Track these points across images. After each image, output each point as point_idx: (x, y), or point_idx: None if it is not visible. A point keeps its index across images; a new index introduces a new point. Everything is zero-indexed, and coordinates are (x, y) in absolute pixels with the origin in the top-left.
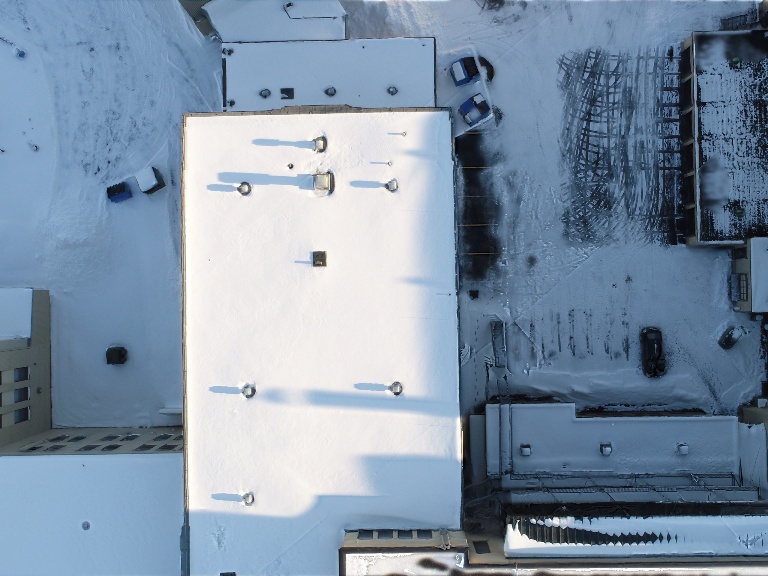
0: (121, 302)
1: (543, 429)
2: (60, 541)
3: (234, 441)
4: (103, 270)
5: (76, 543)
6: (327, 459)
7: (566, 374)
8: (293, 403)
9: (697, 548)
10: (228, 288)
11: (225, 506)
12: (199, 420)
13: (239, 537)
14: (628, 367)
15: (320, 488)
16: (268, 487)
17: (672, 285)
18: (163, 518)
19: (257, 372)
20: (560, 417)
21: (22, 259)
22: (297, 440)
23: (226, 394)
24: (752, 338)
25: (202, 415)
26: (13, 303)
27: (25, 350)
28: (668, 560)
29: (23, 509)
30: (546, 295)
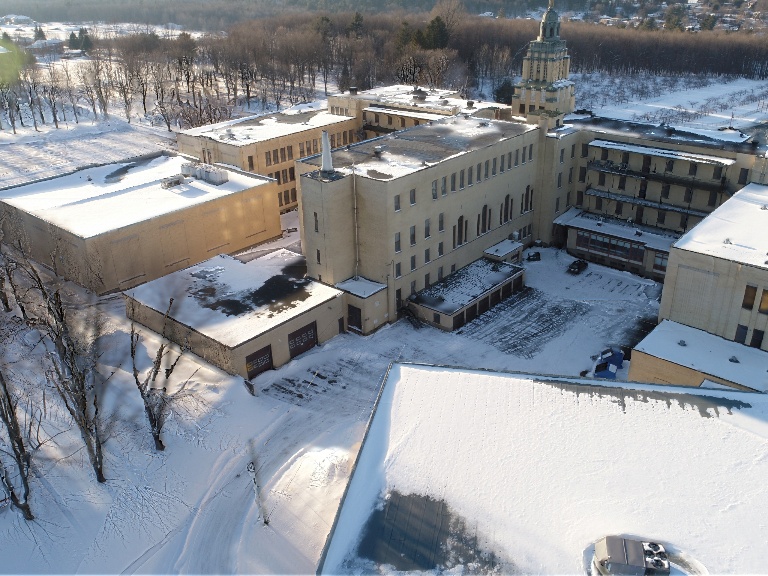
0: None
1: None
2: None
3: None
4: None
5: None
6: None
7: (632, 278)
8: None
9: (646, 148)
10: None
11: None
12: None
13: None
14: (595, 270)
15: None
16: None
17: (546, 279)
18: None
19: None
20: None
21: None
22: None
23: None
24: None
25: None
26: None
27: None
28: (663, 144)
29: None
30: None
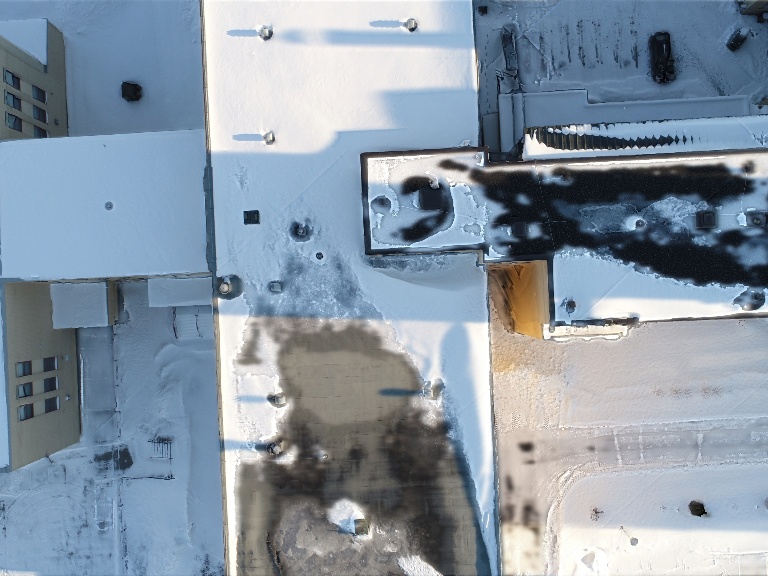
0: (134, 38)
1: (556, 116)
2: (84, 222)
3: (253, 82)
4: (115, 5)
5: (100, 223)
6: (345, 96)
7: (576, 83)
8: (310, 43)
9: (713, 147)
10: None
11: (246, 146)
12: (218, 63)
13: (261, 176)
14: (638, 74)
15: (339, 125)
16: (288, 125)
17: None
18: (185, 194)
19: (274, 14)
20: (572, 104)
21: (35, 1)
22: (315, 79)
23: (244, 37)
24: (760, 40)
25: (221, 58)
26: (28, 32)
27: (42, 74)
28: None
29: (47, 193)
30: (554, 7)
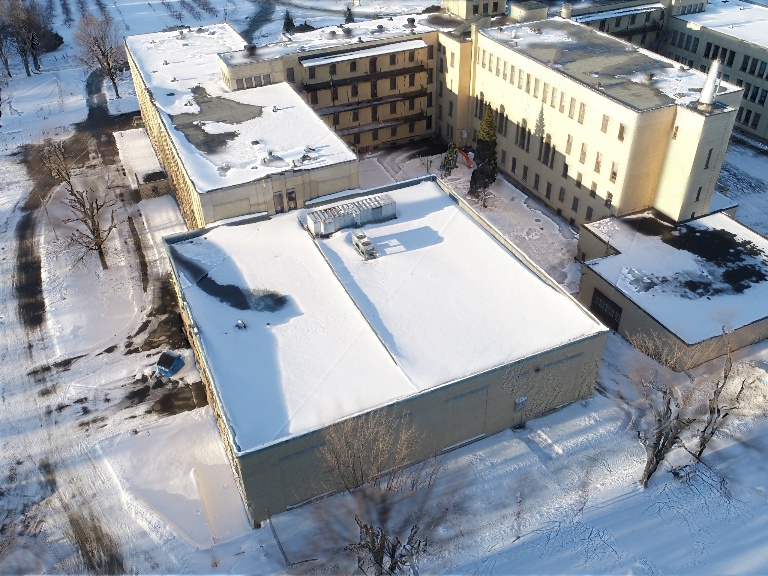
0: None
1: None
2: None
3: (764, 13)
4: None
5: None
6: None
7: None
8: None
9: None
10: None
11: (747, 7)
12: None
13: None
14: None
15: None
16: None
17: None
18: None
19: None
20: None
21: None
22: None
23: None
24: None
25: None
26: None
27: None
28: None
29: None
30: None
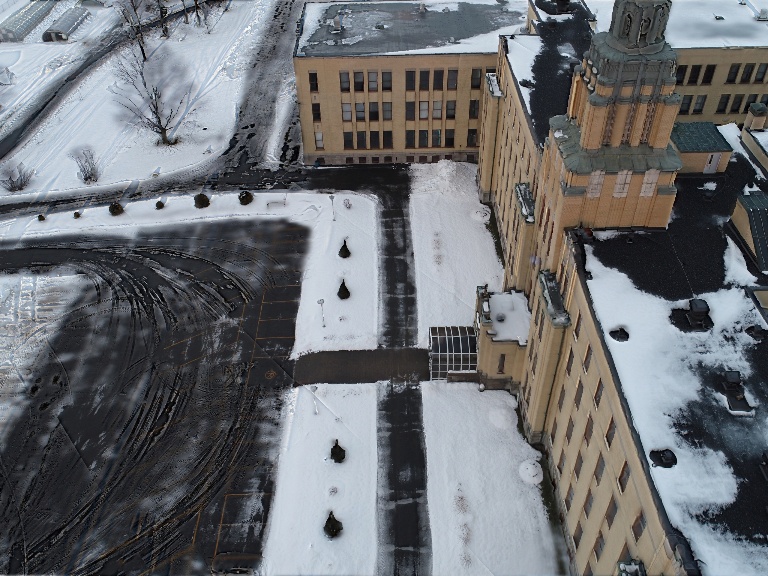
0: None
1: None
2: None
3: (611, 3)
4: None
5: None
6: None
7: None
8: None
9: None
10: (688, 1)
11: None
12: None
13: None
14: None
15: None
16: None
17: None
18: None
19: None
20: None
21: None
22: None
23: None
24: None
25: None
26: None
27: None
28: None
29: None
30: None
